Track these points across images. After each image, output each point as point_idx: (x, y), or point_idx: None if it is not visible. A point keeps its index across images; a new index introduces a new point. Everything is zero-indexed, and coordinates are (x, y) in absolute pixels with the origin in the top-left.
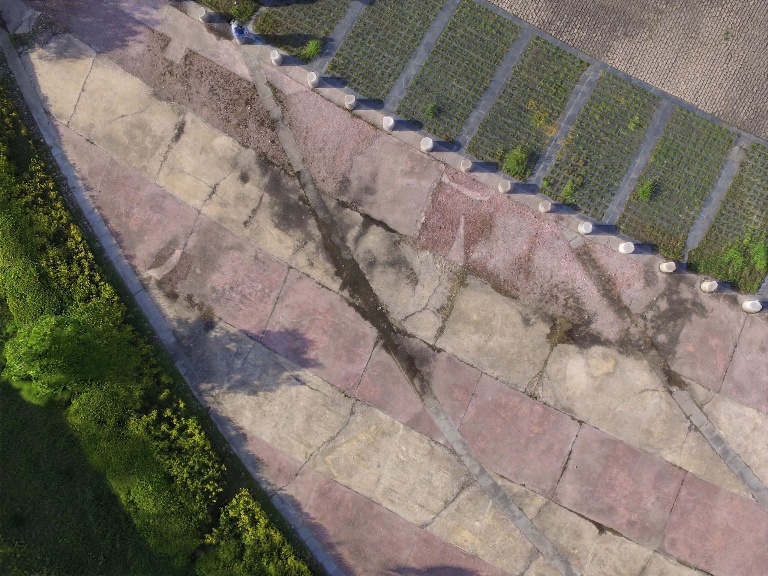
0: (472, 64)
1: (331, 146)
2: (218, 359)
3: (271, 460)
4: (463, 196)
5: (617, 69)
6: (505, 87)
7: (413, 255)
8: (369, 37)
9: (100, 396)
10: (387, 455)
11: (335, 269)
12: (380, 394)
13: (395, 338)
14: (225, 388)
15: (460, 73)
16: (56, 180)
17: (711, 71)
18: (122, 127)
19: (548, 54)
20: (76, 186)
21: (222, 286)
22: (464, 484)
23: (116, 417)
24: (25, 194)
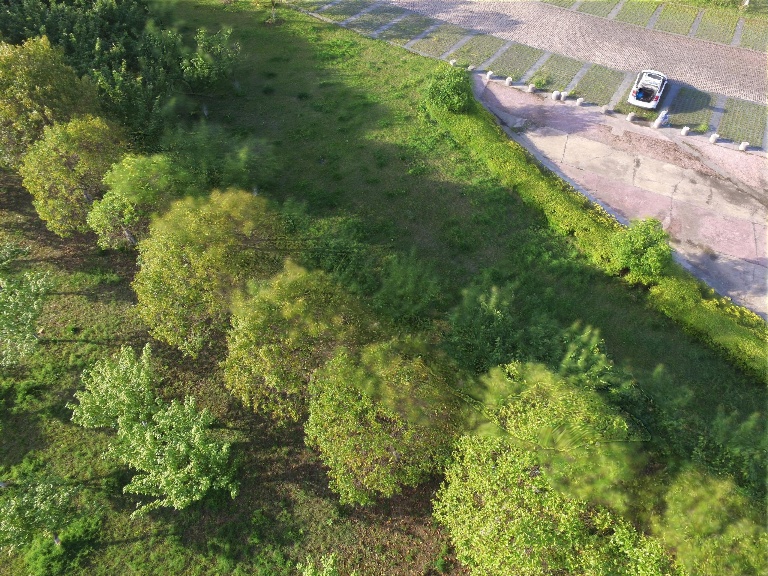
0: None
1: (742, 166)
2: (732, 276)
3: None
4: None
5: None
6: None
7: None
8: None
9: (675, 285)
10: None
11: None
12: None
13: None
14: (748, 294)
15: None
16: None
17: None
18: (599, 162)
19: None
20: (579, 189)
21: (710, 235)
22: None
23: (694, 299)
24: None
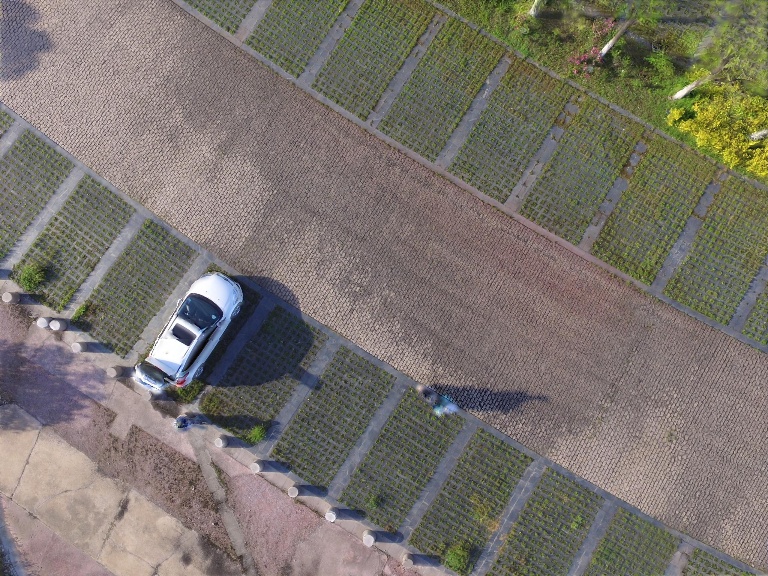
0: (416, 455)
1: (274, 532)
2: None
3: None
4: None
5: (561, 466)
6: (449, 479)
7: None
8: (315, 422)
9: None
10: None
11: None
12: None
13: None
14: None
15: (404, 463)
16: None
17: (654, 474)
18: (66, 502)
19: (492, 449)
20: (18, 560)
21: None
22: None
23: None
24: None
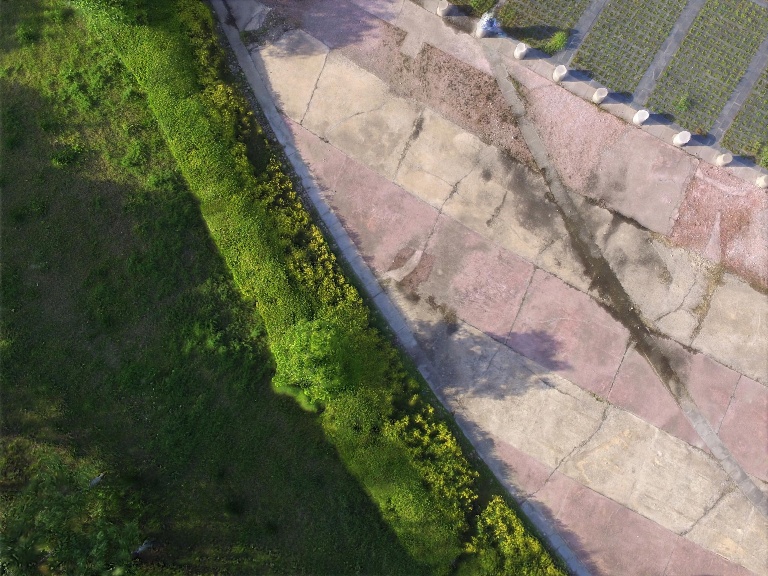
0: (727, 54)
1: (578, 141)
2: (462, 362)
3: (520, 466)
4: (719, 192)
5: None
6: (762, 78)
7: (667, 253)
8: (616, 28)
9: (355, 402)
10: (642, 460)
11: (584, 269)
12: (634, 397)
13: (649, 339)
14: (470, 392)
15: (713, 64)
16: (292, 180)
17: None
18: (358, 125)
19: None
20: (311, 186)
21: (465, 287)
22: (724, 490)
23: (372, 423)
24: (267, 195)
